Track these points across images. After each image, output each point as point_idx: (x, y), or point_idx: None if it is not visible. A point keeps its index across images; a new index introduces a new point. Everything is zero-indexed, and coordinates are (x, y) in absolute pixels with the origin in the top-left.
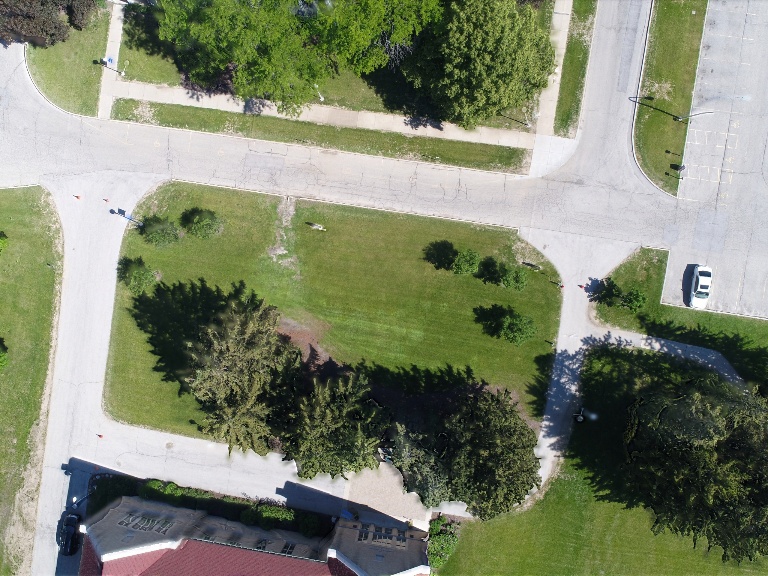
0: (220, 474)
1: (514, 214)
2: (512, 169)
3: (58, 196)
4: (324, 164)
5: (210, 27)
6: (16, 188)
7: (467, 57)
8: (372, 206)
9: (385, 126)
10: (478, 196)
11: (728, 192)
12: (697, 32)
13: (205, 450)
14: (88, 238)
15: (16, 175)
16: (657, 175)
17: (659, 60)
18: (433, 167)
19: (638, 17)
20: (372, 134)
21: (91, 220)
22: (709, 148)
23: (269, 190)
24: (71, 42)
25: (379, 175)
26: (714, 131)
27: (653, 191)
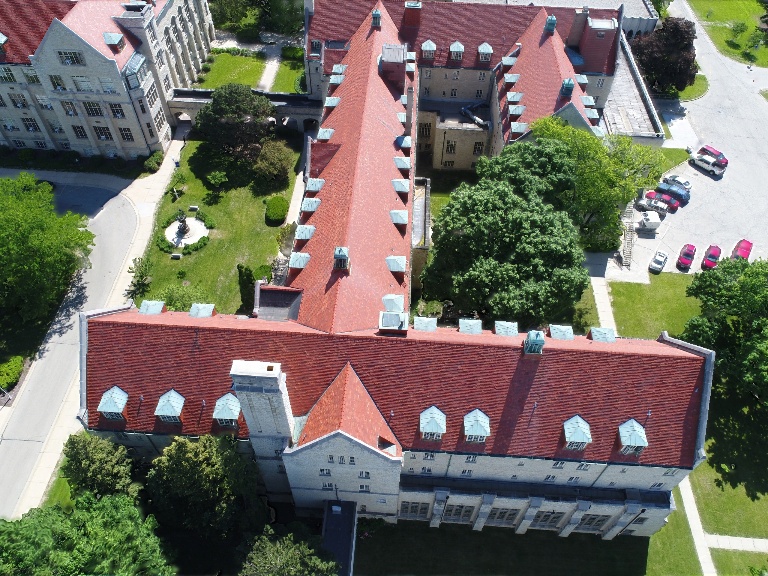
0: None
1: None
2: None
3: (759, 87)
4: None
5: None
6: (767, 101)
7: None
8: None
9: None
10: None
11: None
12: None
13: None
14: None
15: (760, 102)
16: None
17: None
18: None
19: None
20: None
21: (762, 77)
22: None
23: None
24: None
25: (671, 2)
26: None
27: None
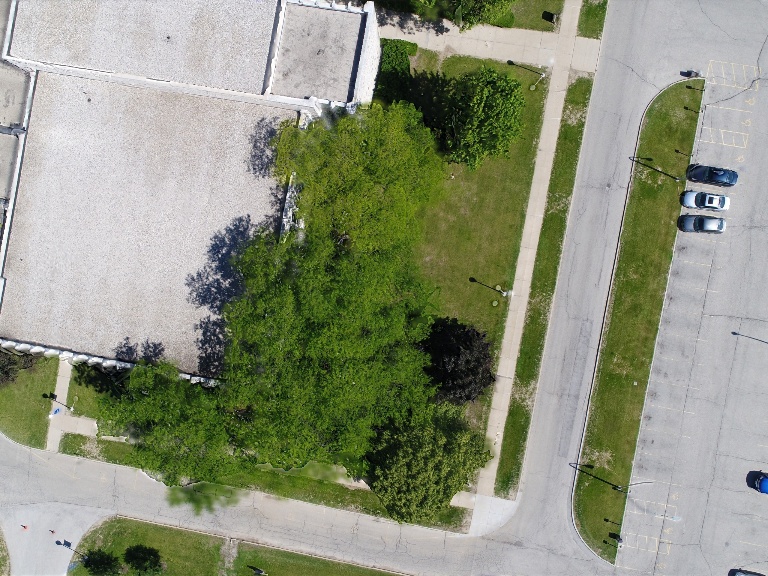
0: None
1: (453, 571)
2: (452, 527)
3: (5, 525)
4: (267, 509)
5: (142, 456)
6: None
7: (394, 501)
8: (313, 554)
9: (328, 476)
10: (418, 551)
11: (666, 563)
12: (638, 403)
13: None
14: (34, 567)
15: None
16: (595, 543)
17: (600, 429)
18: (374, 519)
19: (580, 384)
20: (315, 484)
21: (37, 550)
22: (648, 518)
23: (213, 531)
24: (22, 375)
25: (321, 523)
26: (653, 501)
27: (591, 557)
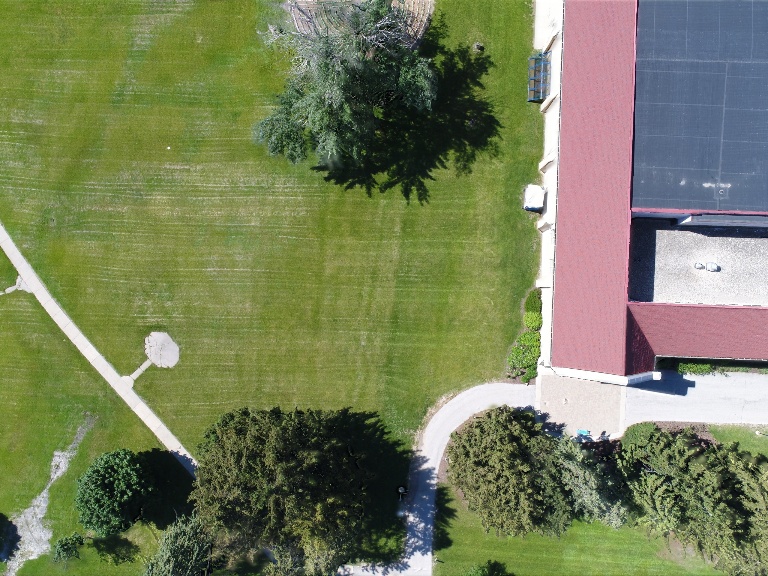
0: (755, 392)
1: None
2: None
3: None
4: None
5: None
6: None
7: None
8: None
9: None
10: None
11: None
12: None
13: None
14: None
15: None
16: None
17: None
18: None
19: None
20: None
21: None
22: None
23: None
24: None
25: None
26: None
27: None
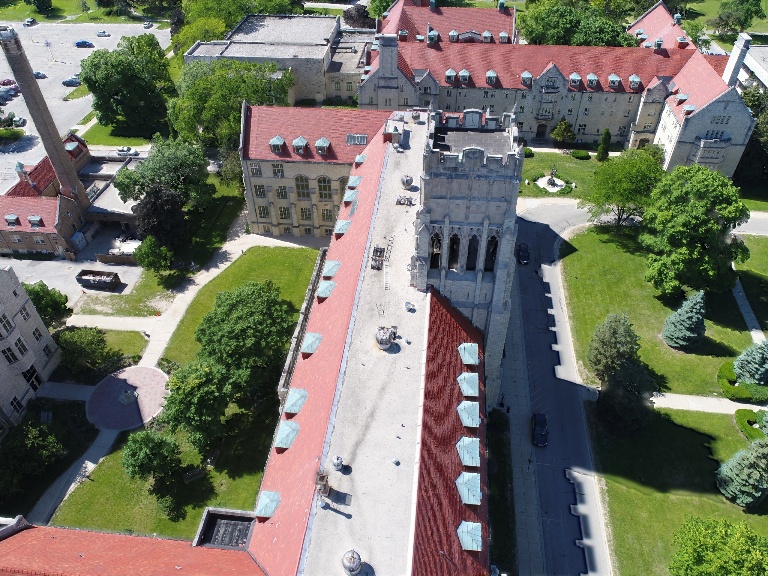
0: (308, 4)
1: None
2: None
3: None
4: None
5: None
6: None
7: None
8: None
9: None
10: None
11: None
12: None
13: (312, 6)
14: None
15: None
16: None
17: None
18: None
19: None
20: None
21: None
22: None
23: None
24: None
25: None
26: None
27: None
